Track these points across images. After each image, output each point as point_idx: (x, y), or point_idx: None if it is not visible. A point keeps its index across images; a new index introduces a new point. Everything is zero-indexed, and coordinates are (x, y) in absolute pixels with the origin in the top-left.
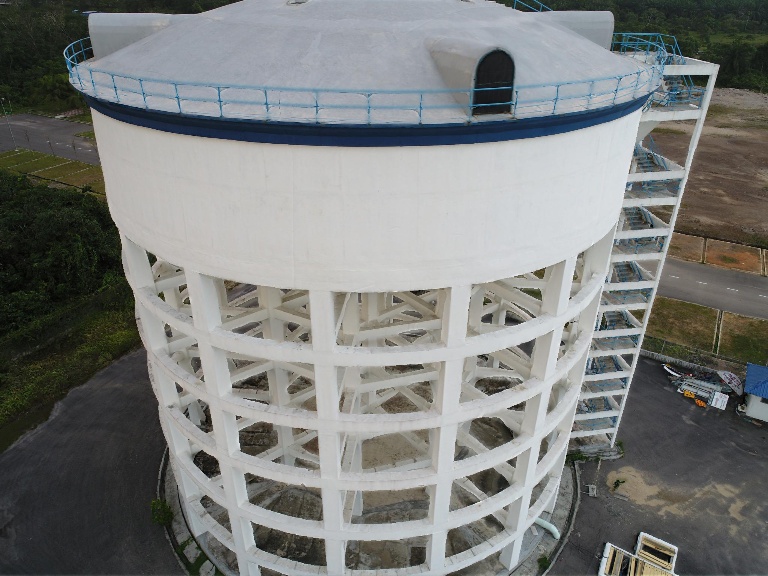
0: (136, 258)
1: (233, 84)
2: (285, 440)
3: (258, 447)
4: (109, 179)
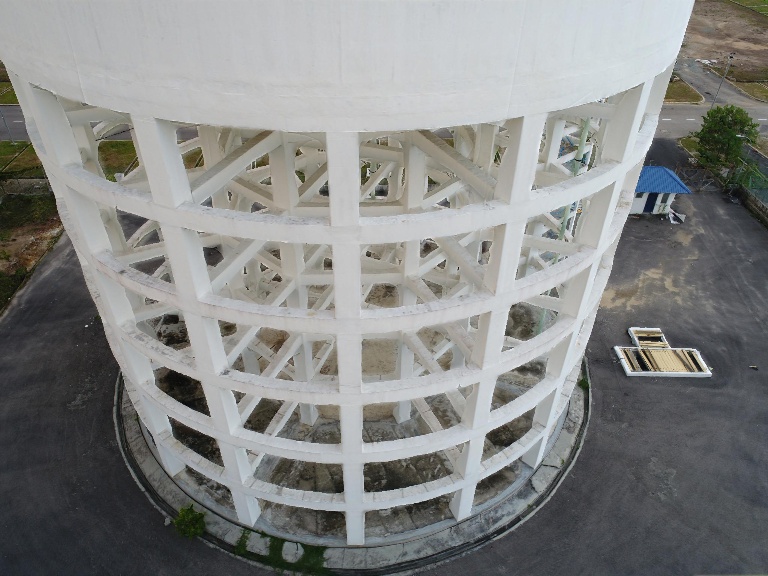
0: (170, 157)
1: None
2: (308, 374)
3: None
4: (105, 21)
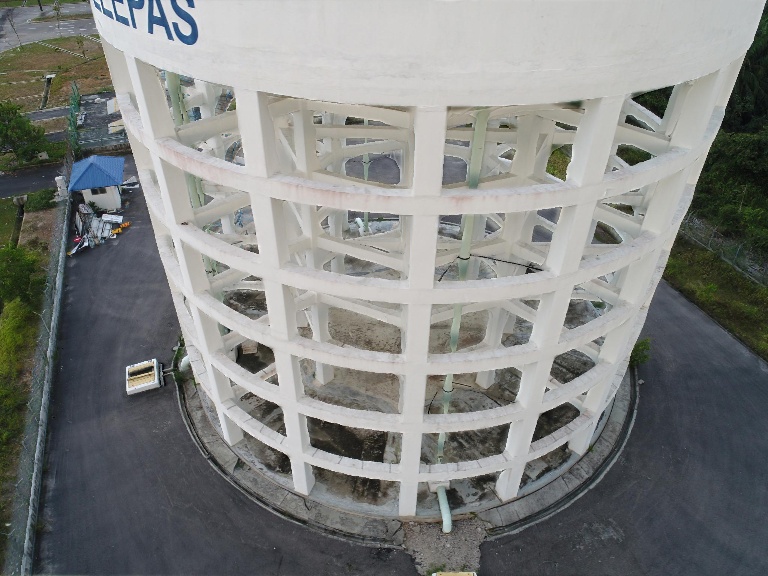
0: None
1: None
2: None
3: (520, 375)
4: None
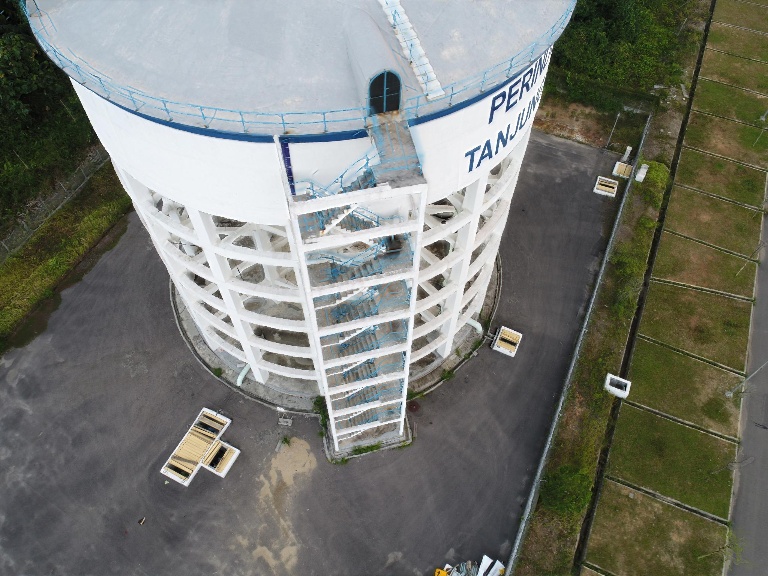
0: None
1: None
2: None
3: None
4: None
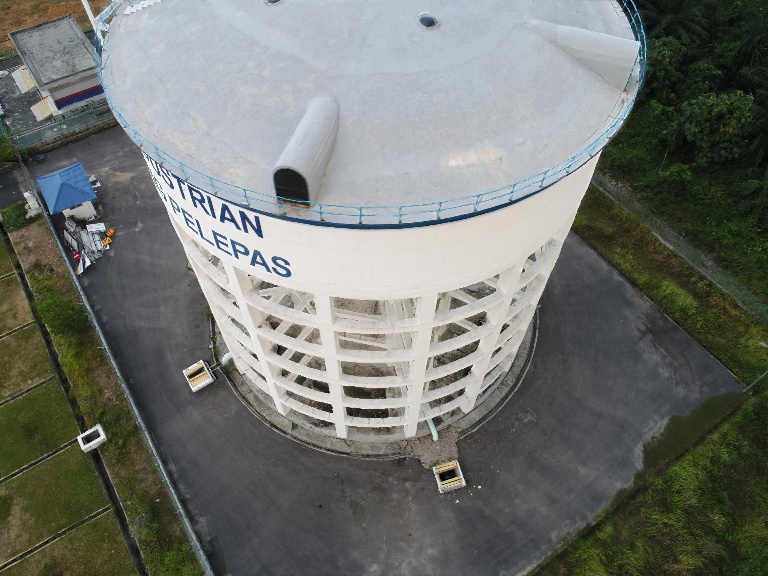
0: None
1: None
2: None
3: None
4: None
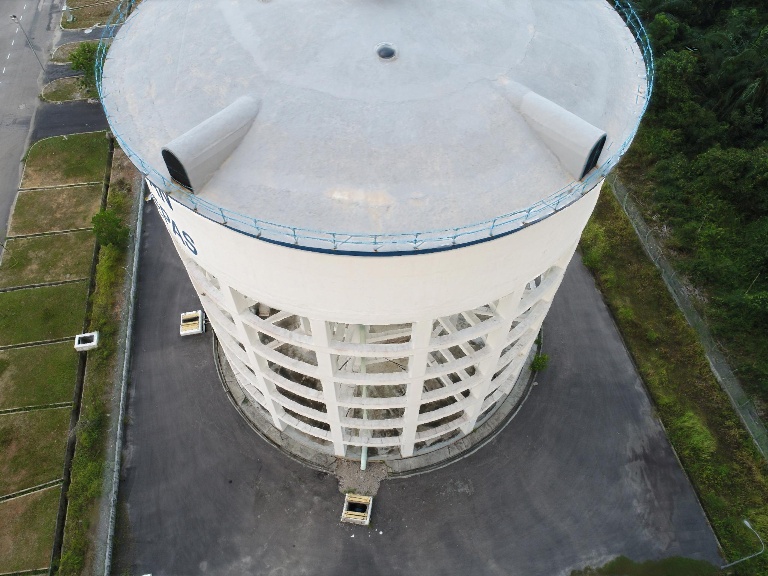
0: None
1: (578, 0)
2: None
3: None
4: None
